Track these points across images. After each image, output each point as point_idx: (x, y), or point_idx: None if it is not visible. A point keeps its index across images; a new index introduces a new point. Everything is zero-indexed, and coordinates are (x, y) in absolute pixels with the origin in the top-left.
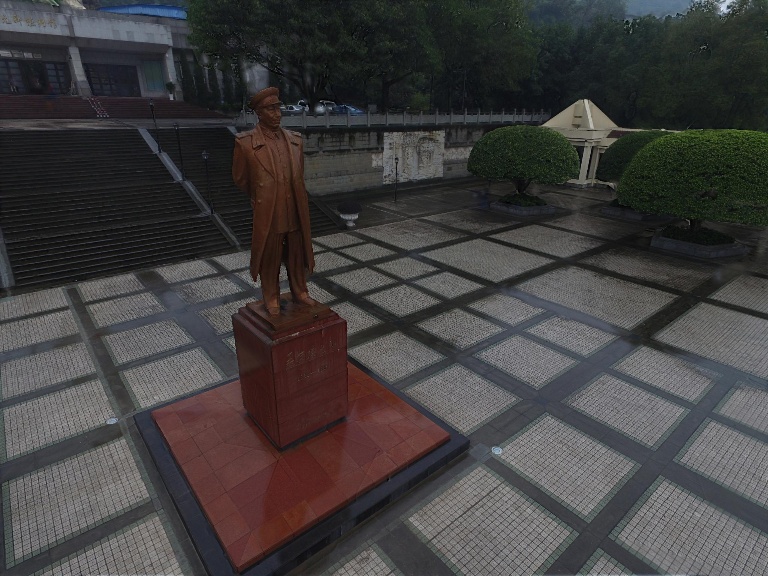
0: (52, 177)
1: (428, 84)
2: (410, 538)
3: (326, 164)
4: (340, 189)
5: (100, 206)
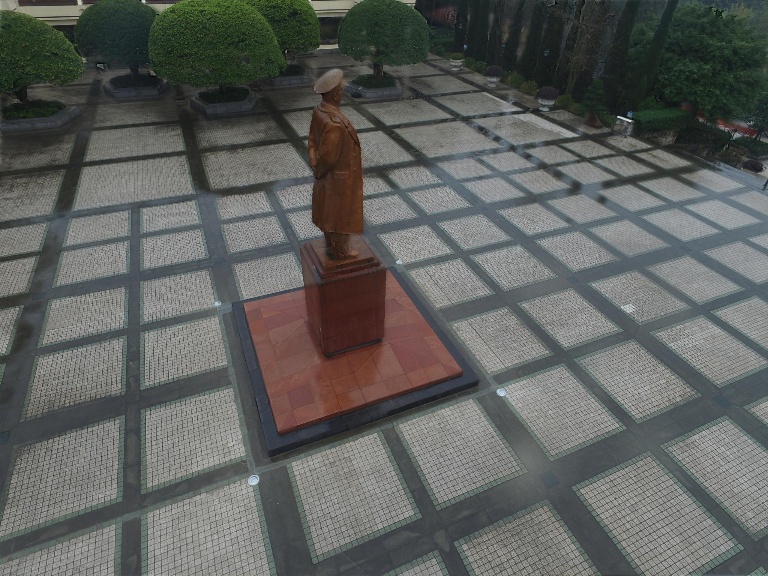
0: None
1: None
2: (449, 310)
3: None
4: None
5: None
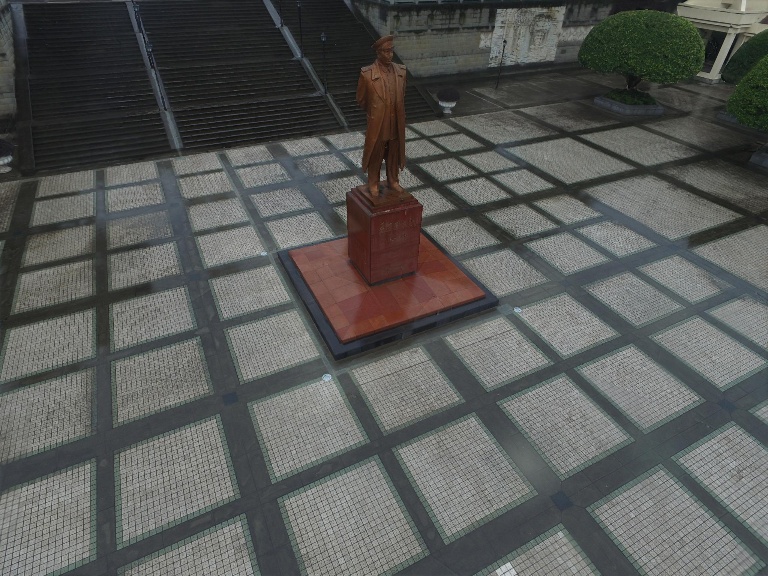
0: (198, 50)
1: None
2: (444, 347)
3: (433, 43)
4: (444, 71)
5: (236, 81)
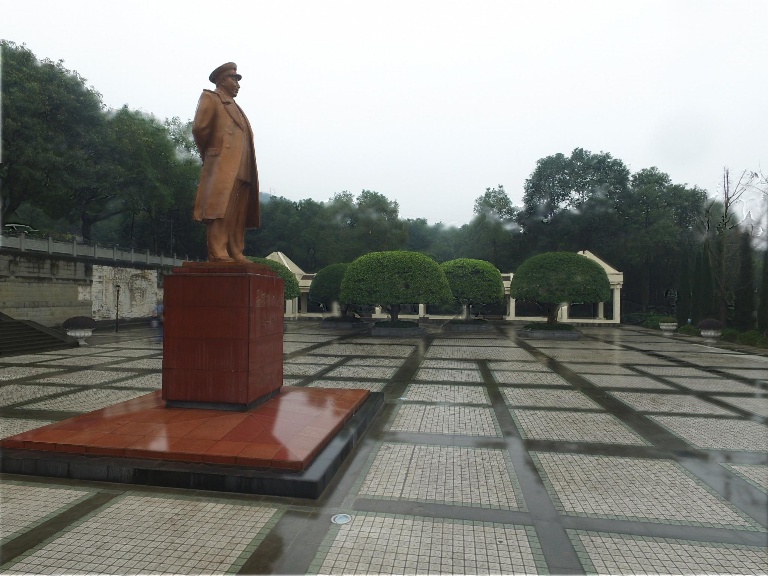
0: None
1: (128, 231)
2: (404, 434)
3: (18, 292)
4: None
5: None
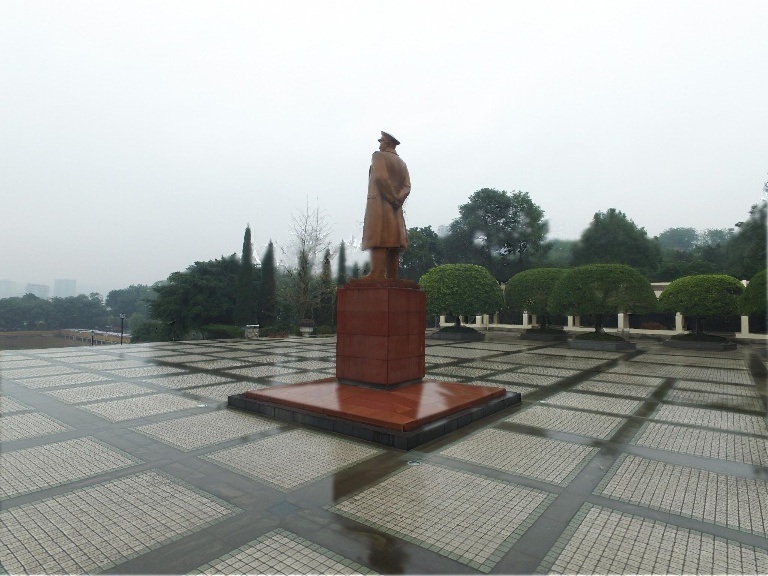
0: None
1: None
2: None
3: None
4: None
5: None
